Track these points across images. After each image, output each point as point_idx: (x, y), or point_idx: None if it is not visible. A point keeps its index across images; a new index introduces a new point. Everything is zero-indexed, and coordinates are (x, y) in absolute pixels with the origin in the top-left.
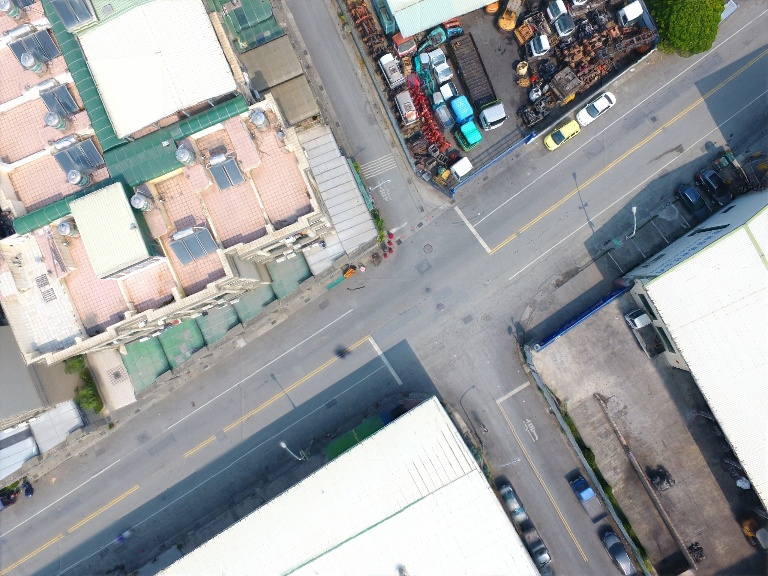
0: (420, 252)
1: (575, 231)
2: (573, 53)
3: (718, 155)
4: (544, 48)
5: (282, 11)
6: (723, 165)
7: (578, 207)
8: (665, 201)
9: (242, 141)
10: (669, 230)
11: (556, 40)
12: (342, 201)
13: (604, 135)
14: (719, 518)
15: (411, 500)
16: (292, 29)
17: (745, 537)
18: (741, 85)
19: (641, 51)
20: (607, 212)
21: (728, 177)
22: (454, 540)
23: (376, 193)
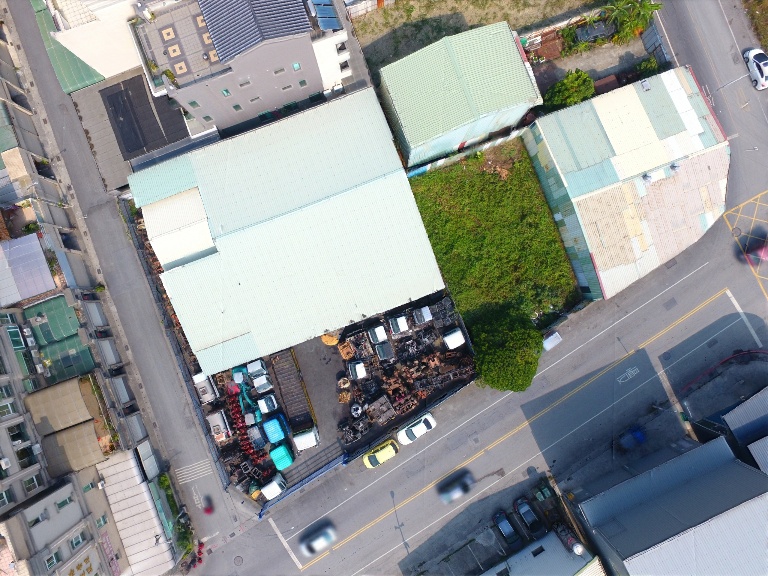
0: (230, 564)
1: (389, 551)
2: (390, 382)
3: (539, 481)
4: (359, 377)
5: (105, 304)
6: (539, 500)
7: (394, 527)
8: (483, 525)
9: None
10: (485, 556)
11: (377, 362)
12: (138, 531)
13: (425, 454)
14: None
15: None
16: (115, 323)
17: None
18: (567, 410)
19: None
20: (423, 533)
21: (548, 505)
22: None
23: (189, 499)
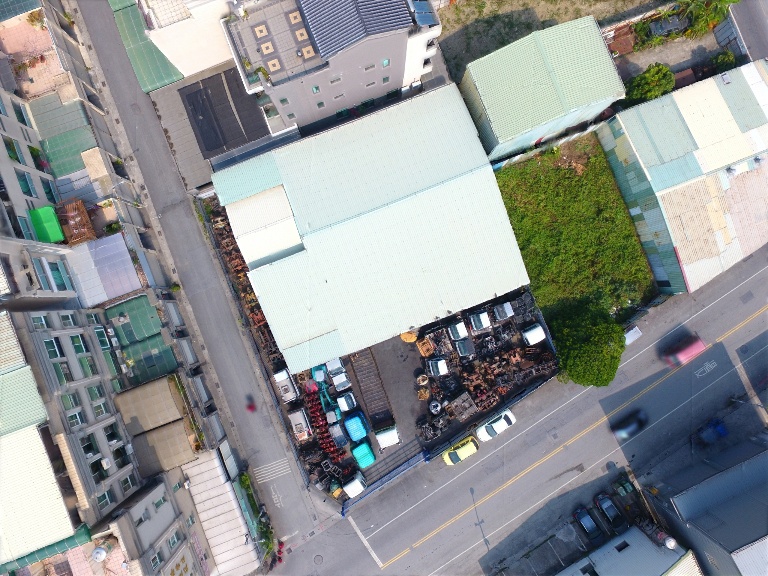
0: (310, 563)
1: (470, 548)
2: (471, 379)
3: (619, 476)
4: (441, 374)
5: (181, 303)
6: (621, 495)
7: (474, 524)
8: (563, 520)
9: (83, 572)
10: (565, 552)
11: (457, 359)
12: (224, 531)
13: (504, 450)
14: None
15: None
16: (190, 322)
17: None
18: (645, 405)
19: (543, 373)
20: (503, 530)
21: (628, 500)
22: None
23: (268, 499)
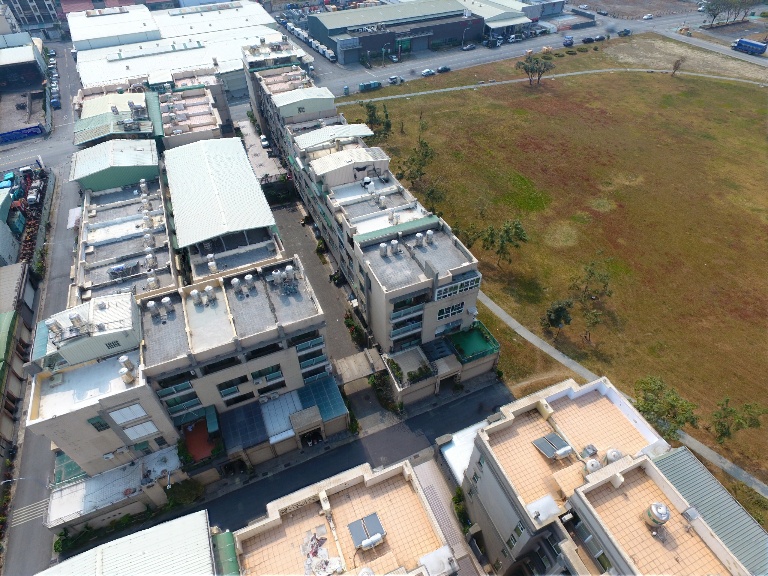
0: None
1: None
2: None
3: None
4: None
5: None
6: None
7: None
8: None
9: None
10: None
11: None
12: None
13: None
14: (7, 101)
15: (115, 80)
16: None
17: (1, 98)
18: None
19: None
20: None
21: None
22: (104, 73)
23: None
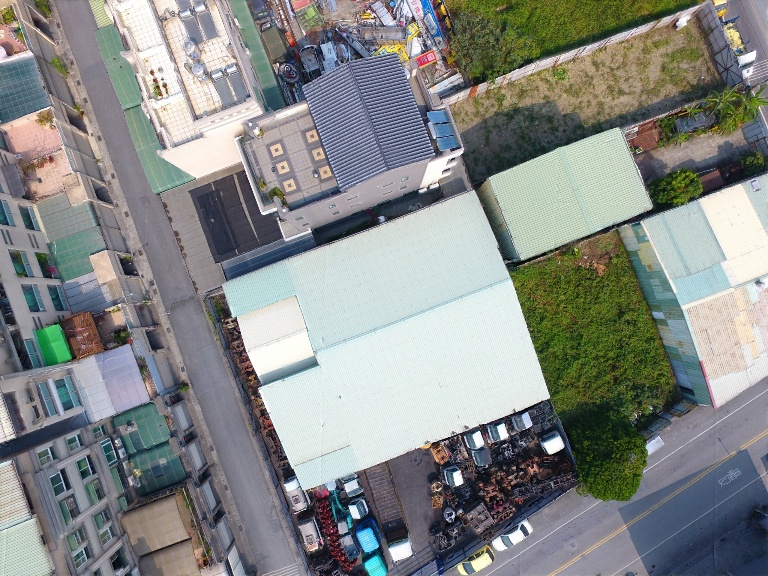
0: None
1: None
2: (488, 490)
3: None
4: (457, 485)
5: (190, 403)
6: None
7: None
8: None
9: None
10: None
11: (472, 467)
12: None
13: (520, 559)
14: None
15: None
16: (199, 422)
17: None
18: (667, 514)
19: None
20: None
21: None
22: None
23: None
